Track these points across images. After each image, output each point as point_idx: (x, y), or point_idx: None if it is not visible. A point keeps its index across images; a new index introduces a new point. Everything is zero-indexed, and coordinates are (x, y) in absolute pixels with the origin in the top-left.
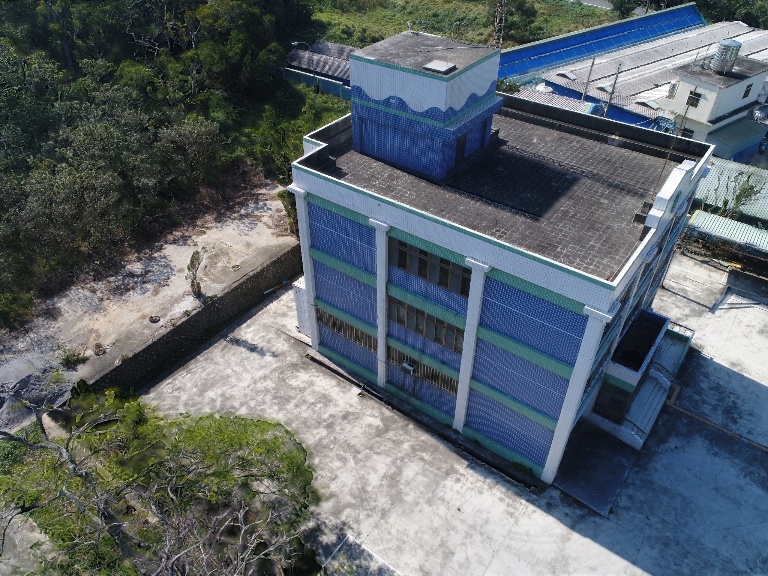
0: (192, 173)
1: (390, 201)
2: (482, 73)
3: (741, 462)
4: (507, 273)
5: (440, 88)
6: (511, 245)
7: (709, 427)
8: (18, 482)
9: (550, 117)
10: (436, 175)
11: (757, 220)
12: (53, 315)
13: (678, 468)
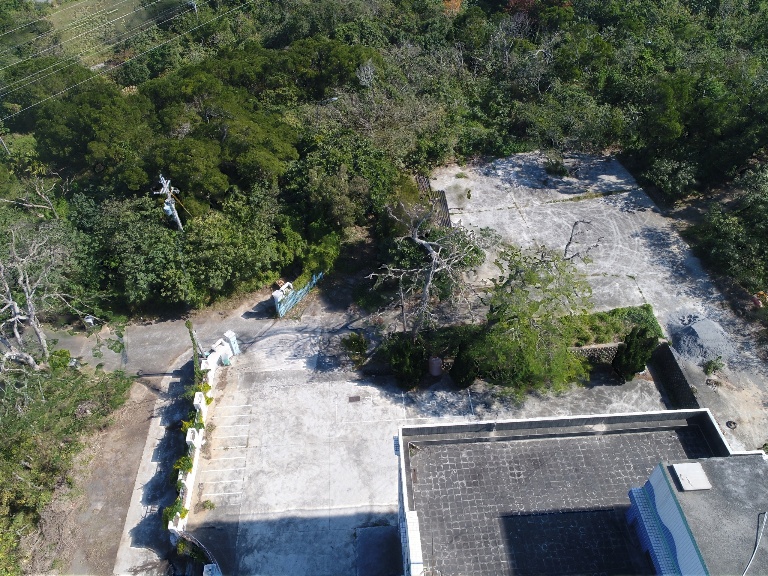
0: None
1: None
2: None
3: None
4: None
5: None
6: (480, 422)
7: None
8: None
9: None
10: None
11: None
12: None
13: None
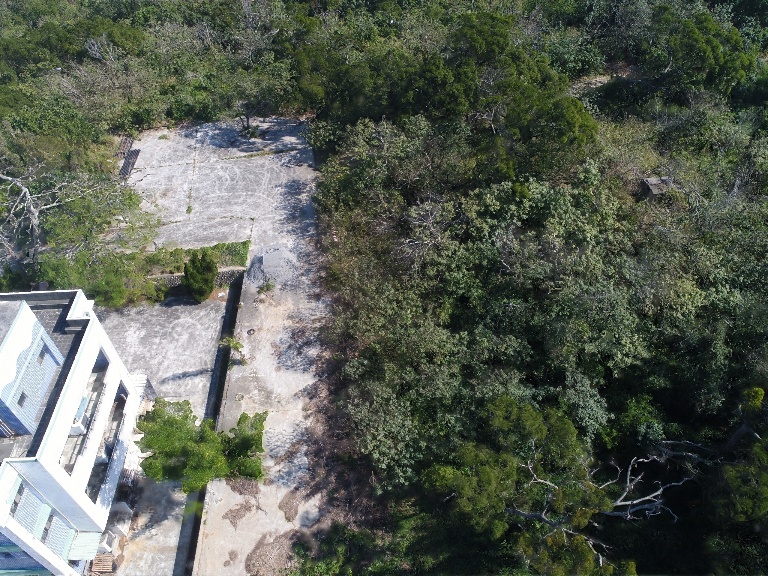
0: None
1: None
2: None
3: None
4: None
5: None
6: None
7: None
8: None
9: None
10: None
11: None
12: (313, 296)
13: None
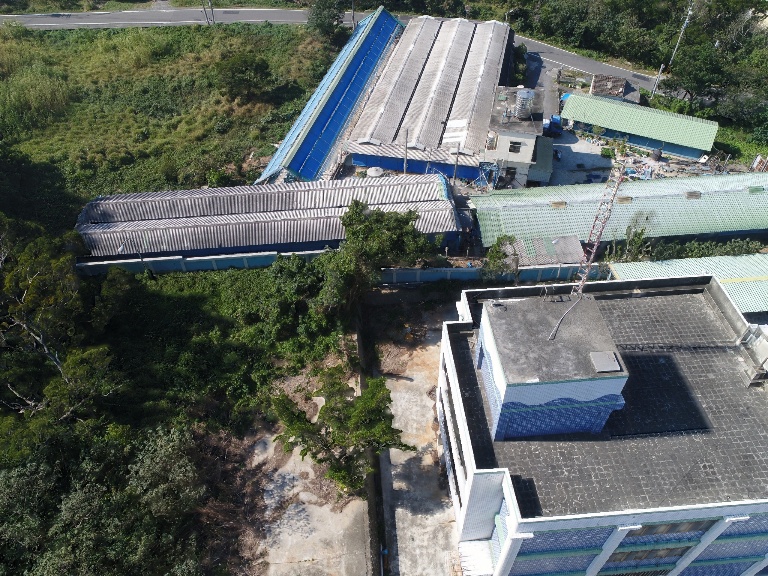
0: None
1: (650, 512)
2: None
3: None
4: (761, 512)
5: (619, 383)
6: None
7: None
8: None
9: None
10: (597, 431)
11: None
12: None
13: None
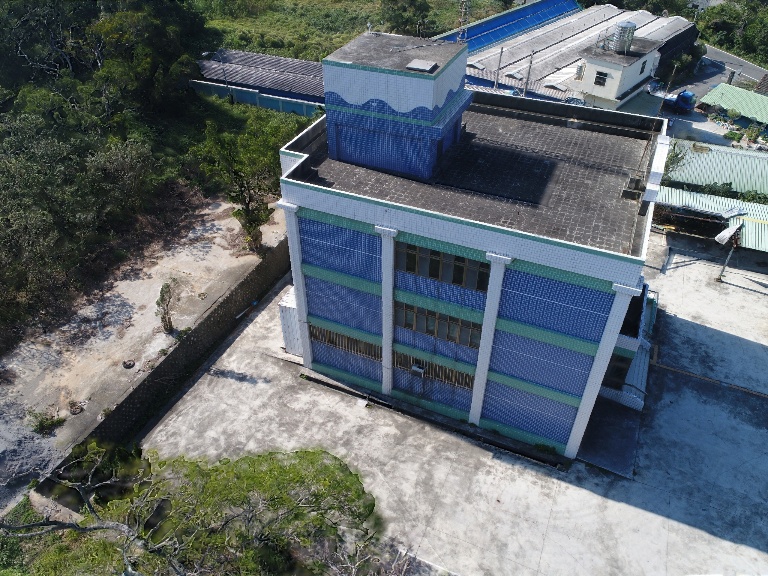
0: (128, 201)
1: (399, 206)
2: (456, 69)
3: (728, 405)
4: (530, 262)
5: (427, 87)
6: (534, 234)
7: (692, 378)
8: (76, 574)
9: (508, 107)
10: (424, 174)
11: (678, 184)
12: (7, 378)
13: (678, 421)
